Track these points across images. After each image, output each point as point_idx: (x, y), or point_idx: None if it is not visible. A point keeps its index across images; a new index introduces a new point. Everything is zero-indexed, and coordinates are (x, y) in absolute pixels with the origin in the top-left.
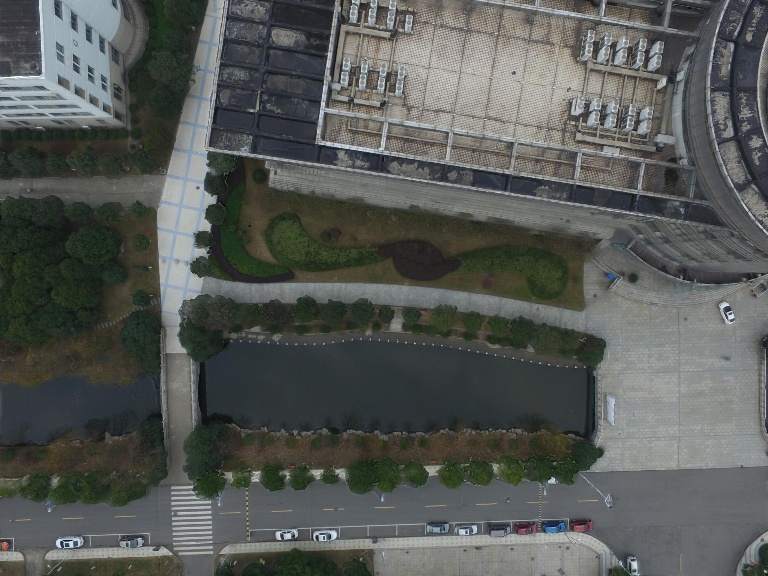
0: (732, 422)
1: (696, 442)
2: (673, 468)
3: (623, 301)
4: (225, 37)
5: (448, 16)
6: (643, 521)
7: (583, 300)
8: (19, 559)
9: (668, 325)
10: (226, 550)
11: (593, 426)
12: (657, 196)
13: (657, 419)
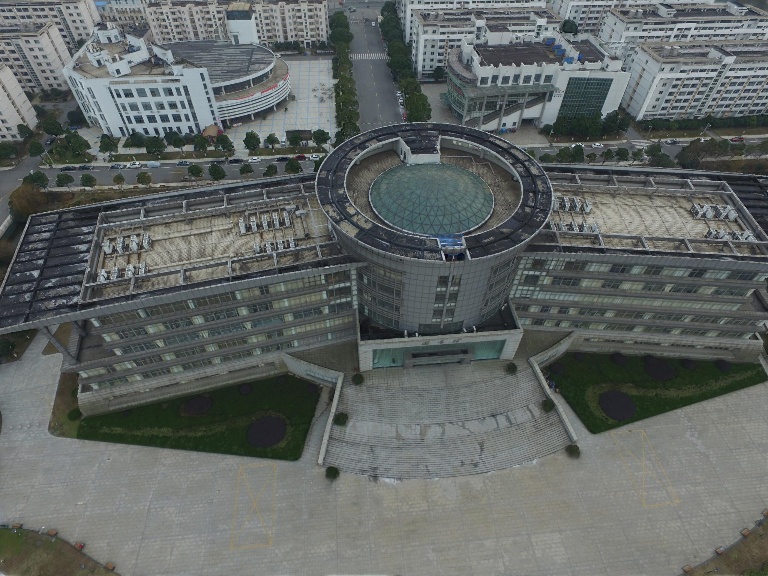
0: None
1: None
2: None
3: None
4: None
5: None
6: None
7: None
8: (723, 137)
9: None
10: (624, 141)
11: None
12: None
13: None
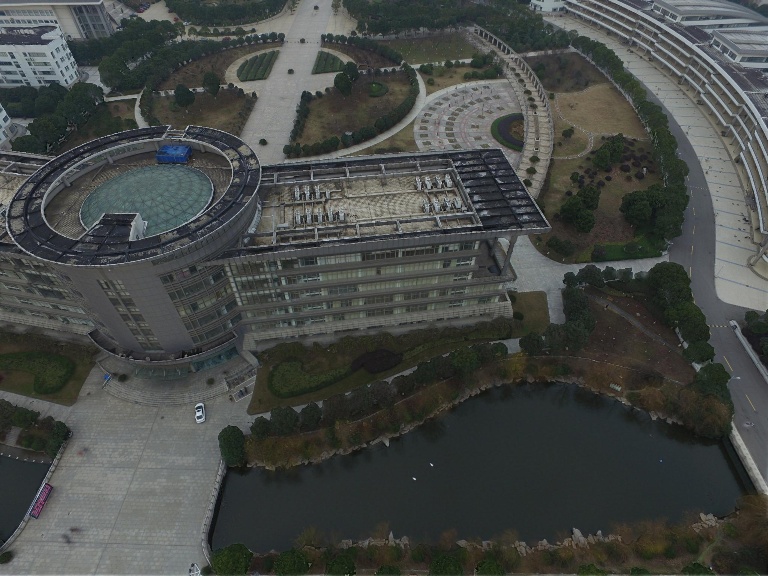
0: (173, 529)
1: (124, 552)
2: None
3: (112, 400)
4: None
5: None
6: None
7: (76, 397)
8: None
9: (144, 422)
10: None
11: None
12: (5, 242)
13: (92, 520)
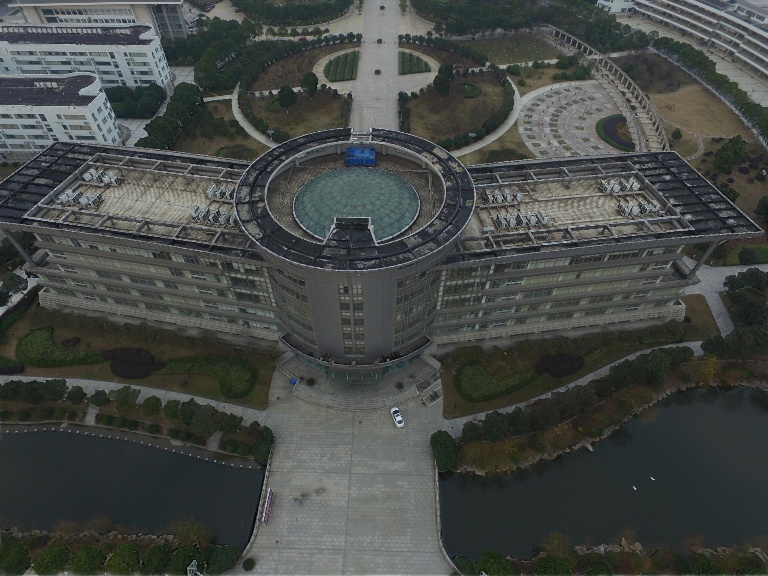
0: (407, 535)
1: (365, 558)
2: None
3: (303, 404)
4: (8, 179)
5: (143, 182)
6: None
7: (267, 401)
8: None
9: (343, 427)
10: None
11: None
12: (224, 246)
13: (322, 526)
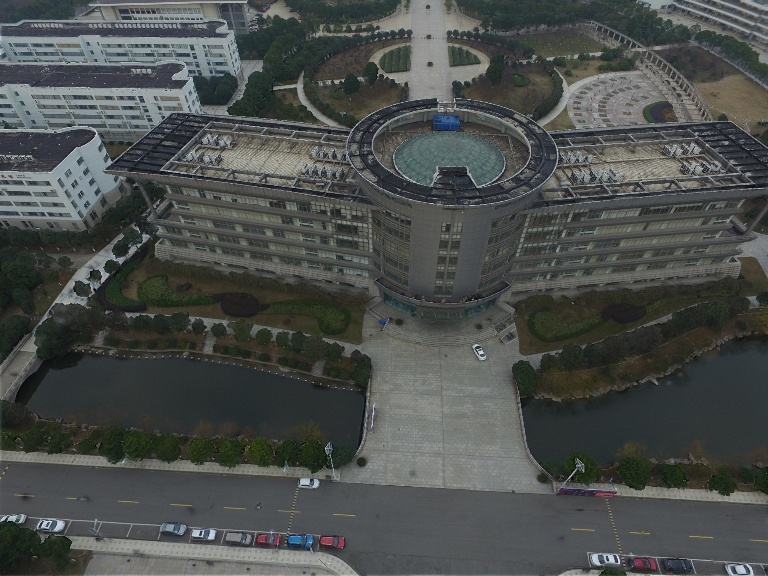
0: (497, 444)
1: (462, 461)
2: (439, 486)
3: (393, 340)
4: (139, 141)
5: (252, 146)
6: (405, 548)
7: (361, 337)
8: None
9: (431, 359)
10: None
11: (360, 439)
12: (336, 193)
13: (421, 435)
